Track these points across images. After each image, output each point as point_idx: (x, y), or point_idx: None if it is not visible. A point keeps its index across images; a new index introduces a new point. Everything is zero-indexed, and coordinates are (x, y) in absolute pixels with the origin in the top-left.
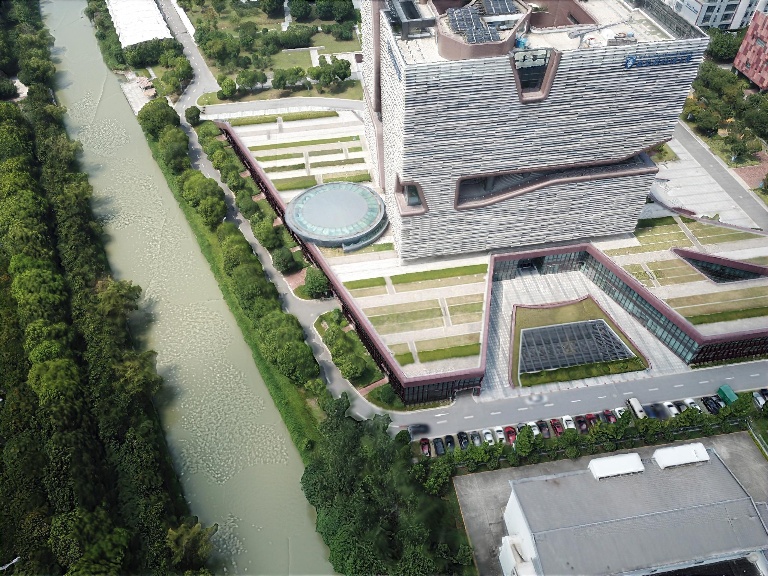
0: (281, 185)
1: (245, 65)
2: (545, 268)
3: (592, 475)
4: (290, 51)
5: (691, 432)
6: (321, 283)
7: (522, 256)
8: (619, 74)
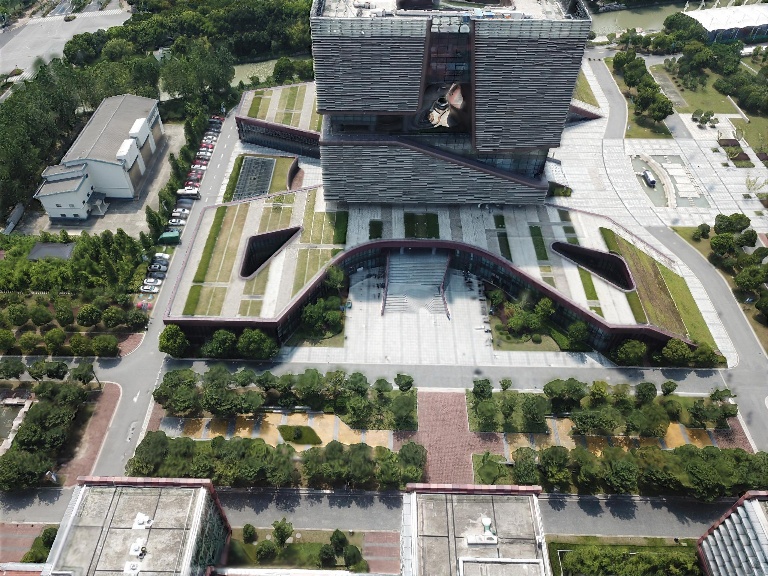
0: None
1: (681, 74)
2: None
3: None
4: (731, 101)
5: None
6: None
7: None
8: None
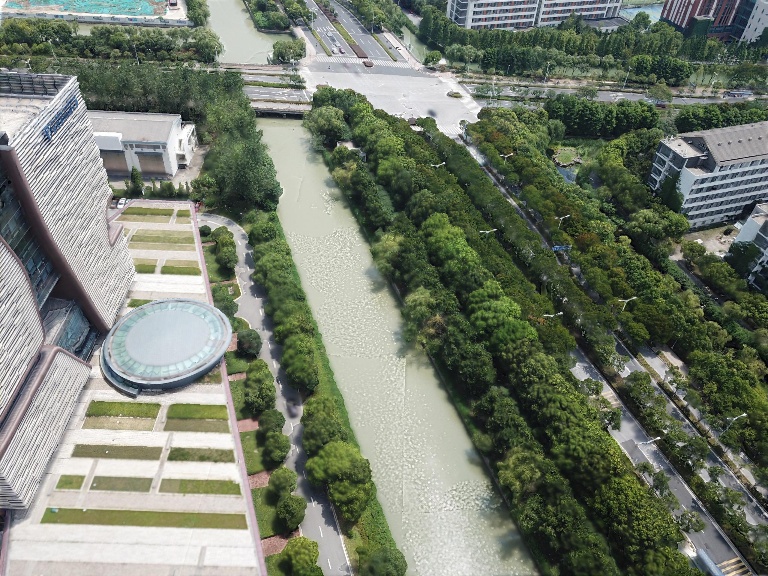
0: (218, 413)
1: None
2: None
3: (122, 138)
4: None
5: None
6: None
7: None
8: None
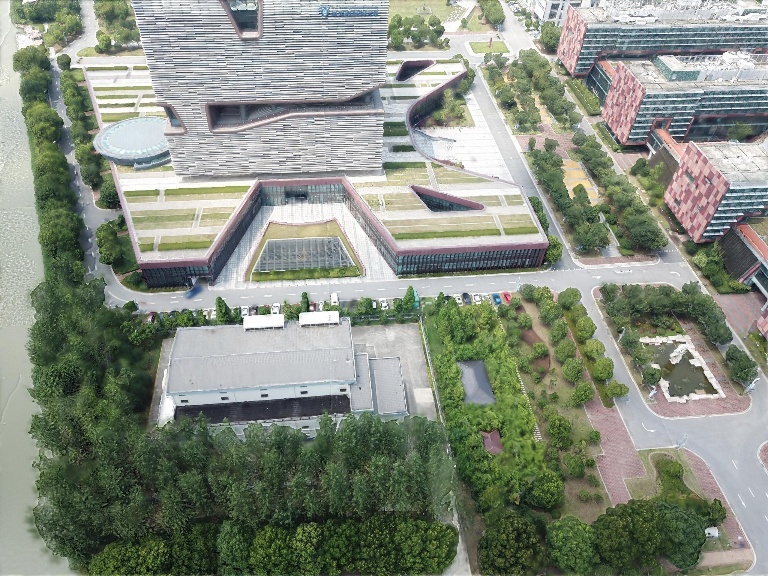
0: (107, 117)
1: (130, 26)
2: (312, 198)
3: None
4: None
5: (372, 321)
6: (111, 193)
7: (285, 183)
8: (319, 21)
